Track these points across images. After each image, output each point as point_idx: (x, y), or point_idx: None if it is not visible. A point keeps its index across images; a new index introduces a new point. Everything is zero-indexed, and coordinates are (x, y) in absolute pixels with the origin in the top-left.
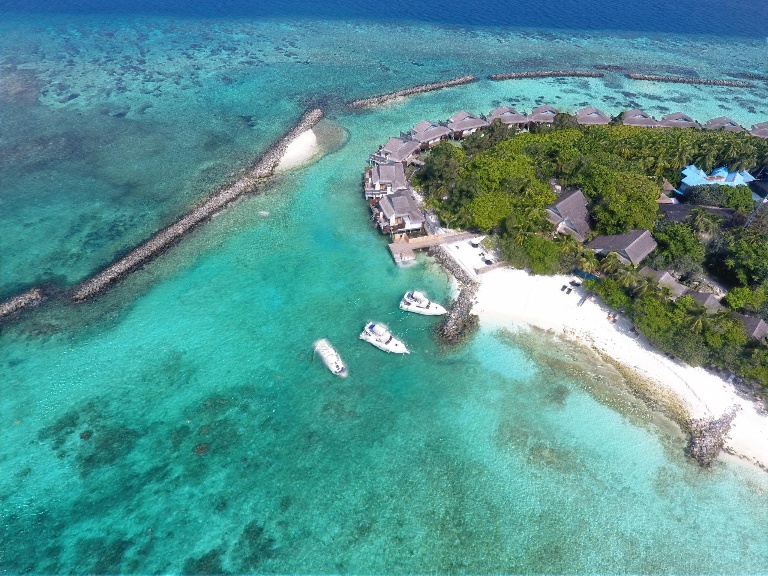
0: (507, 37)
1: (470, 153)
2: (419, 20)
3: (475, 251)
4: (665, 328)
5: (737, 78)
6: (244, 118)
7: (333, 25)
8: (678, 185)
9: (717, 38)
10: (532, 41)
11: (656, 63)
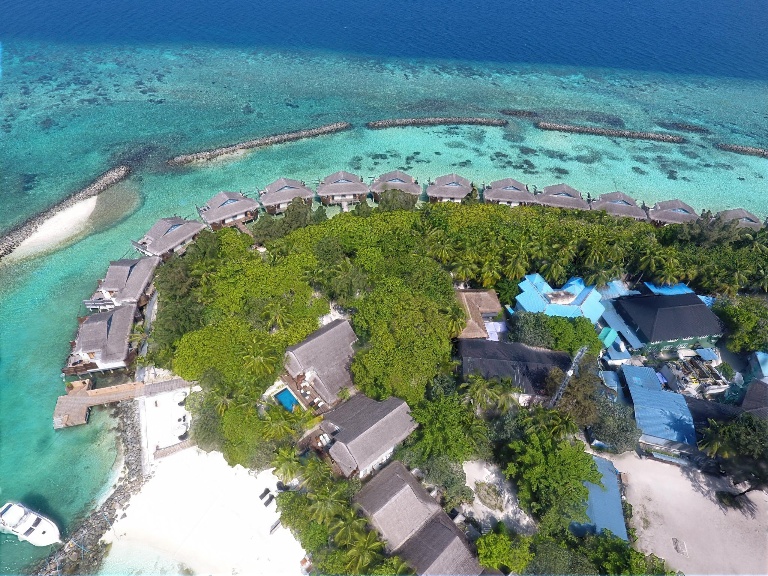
0: (418, 72)
1: (260, 242)
2: (326, 50)
3: (177, 412)
4: None
5: (670, 130)
6: (26, 178)
7: (225, 54)
8: (513, 302)
9: (665, 76)
10: (445, 77)
11: (579, 108)
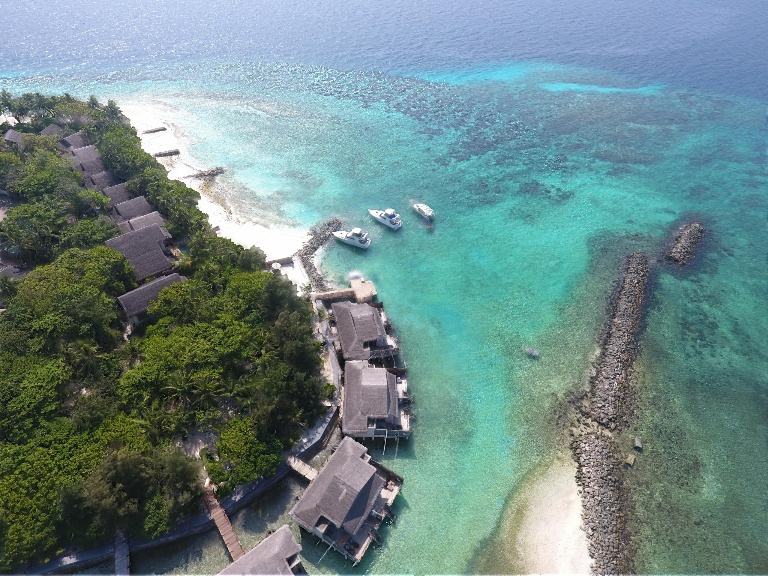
0: None
1: None
2: None
3: None
4: None
5: None
6: None
7: None
8: None
9: None
10: None
11: None
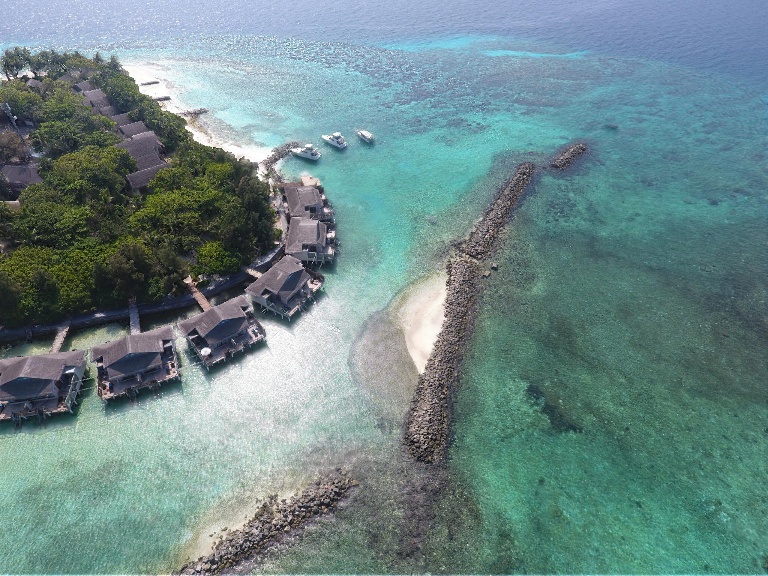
0: None
1: None
2: None
3: None
4: None
5: None
6: (563, 418)
7: None
8: None
9: None
10: None
11: None
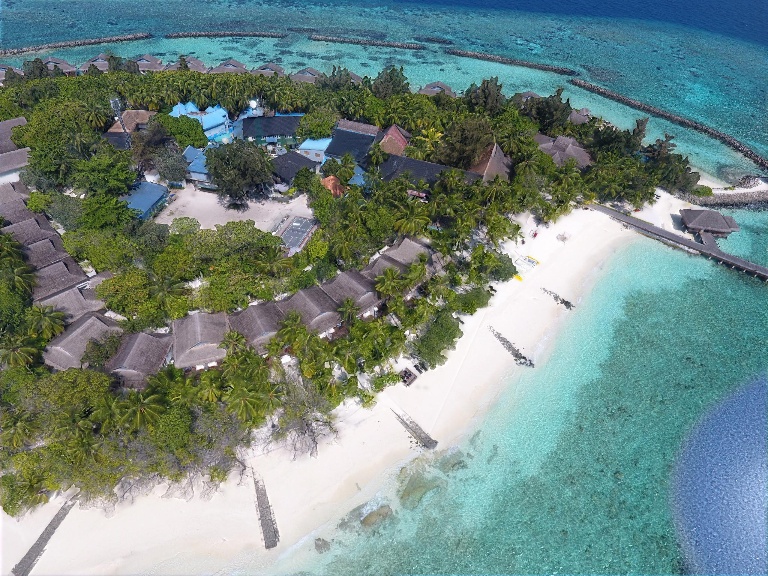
0: (242, 3)
1: None
2: None
3: None
4: None
5: (420, 42)
6: None
7: None
8: None
9: (459, 9)
10: (263, 7)
11: (359, 28)
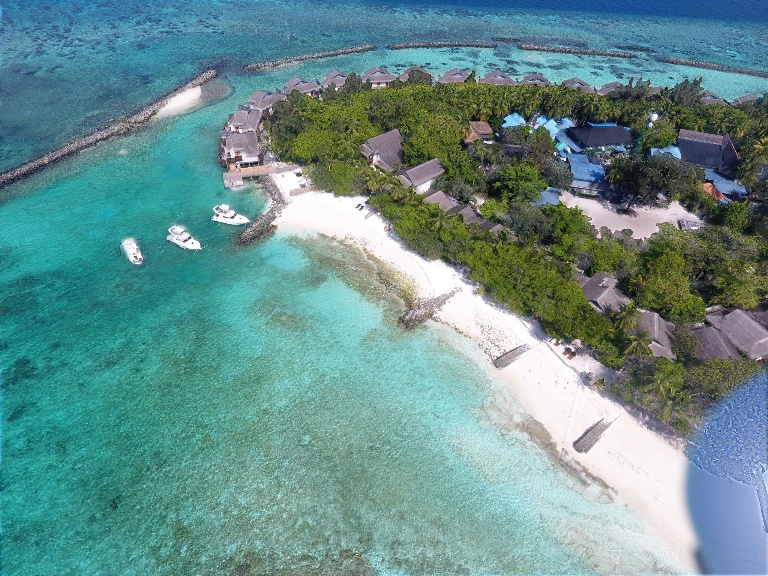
0: (424, 13)
1: None
2: None
3: (297, 179)
4: (413, 229)
5: (623, 50)
6: (143, 77)
7: (262, 2)
8: None
9: (627, 16)
10: (446, 17)
11: (554, 37)
